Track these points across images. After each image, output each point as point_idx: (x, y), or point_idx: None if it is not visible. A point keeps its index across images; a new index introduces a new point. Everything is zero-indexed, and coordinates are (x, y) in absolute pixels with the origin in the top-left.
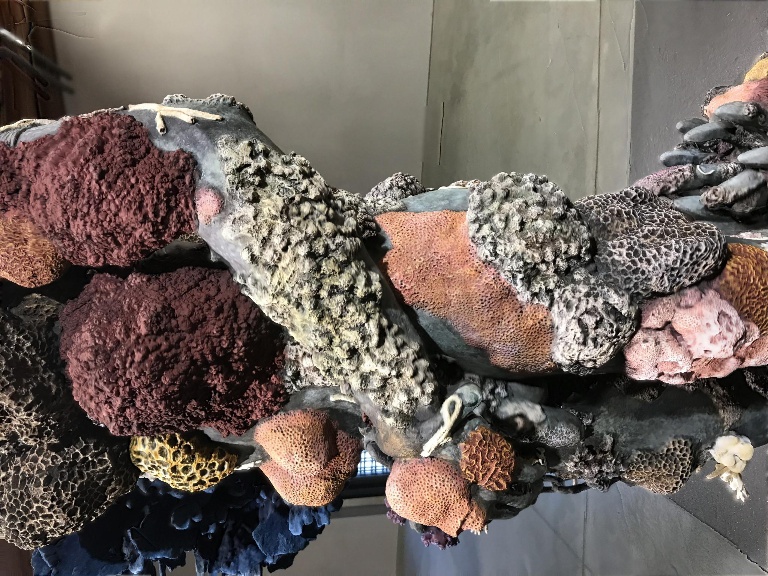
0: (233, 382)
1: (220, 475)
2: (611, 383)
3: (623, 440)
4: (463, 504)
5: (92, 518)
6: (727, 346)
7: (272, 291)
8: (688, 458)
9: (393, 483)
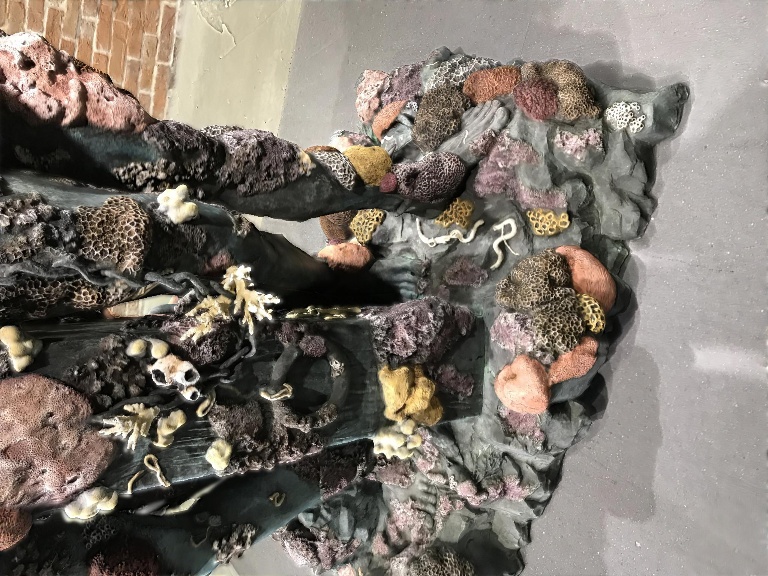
0: None
1: None
2: (17, 171)
3: (55, 200)
4: None
5: None
6: None
7: None
8: (132, 201)
9: None
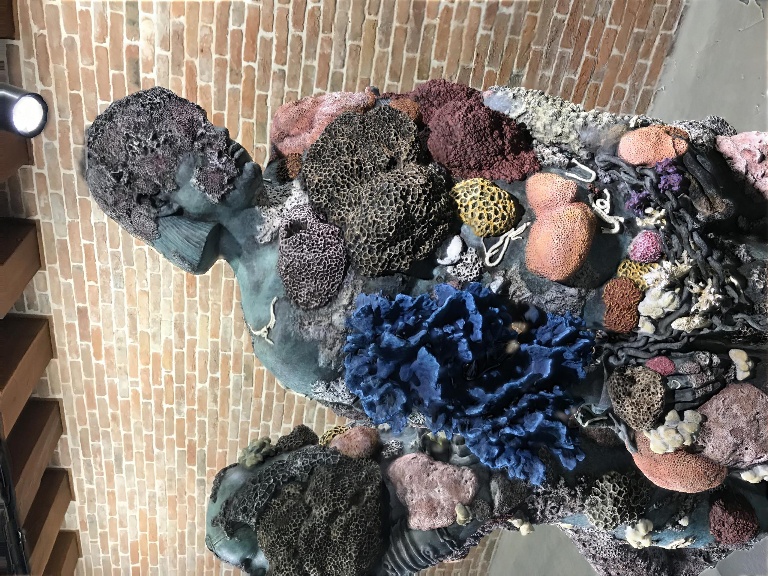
0: (513, 137)
1: (509, 205)
2: (743, 236)
3: None
4: (667, 136)
5: (431, 209)
6: (766, 133)
7: (526, 102)
8: None
9: (622, 138)
